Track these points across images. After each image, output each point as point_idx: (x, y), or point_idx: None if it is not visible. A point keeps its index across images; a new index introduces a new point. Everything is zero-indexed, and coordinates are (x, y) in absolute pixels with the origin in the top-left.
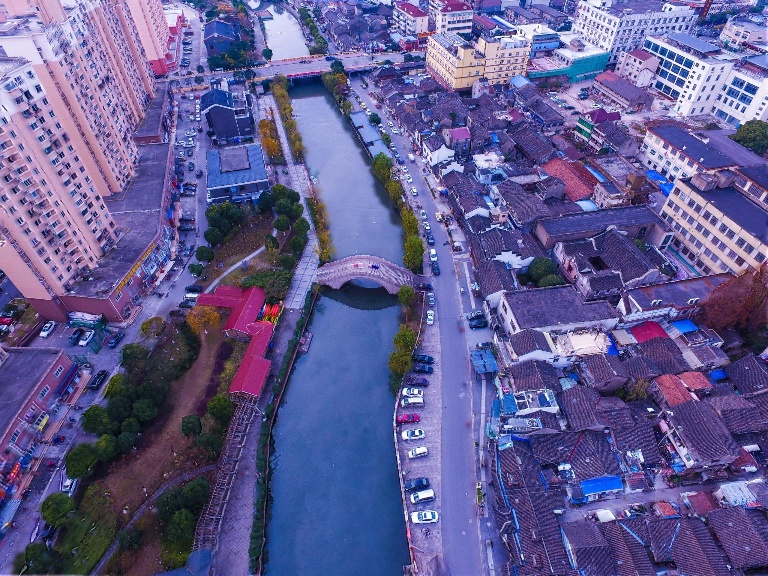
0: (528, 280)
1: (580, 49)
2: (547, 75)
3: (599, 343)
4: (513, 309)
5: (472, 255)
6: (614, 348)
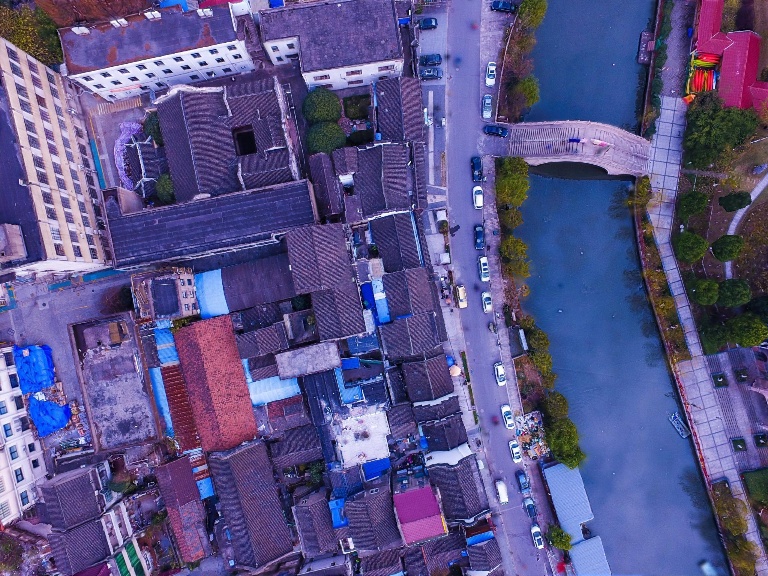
0: (348, 139)
1: None
2: None
3: None
4: (395, 29)
5: None
6: (272, 4)
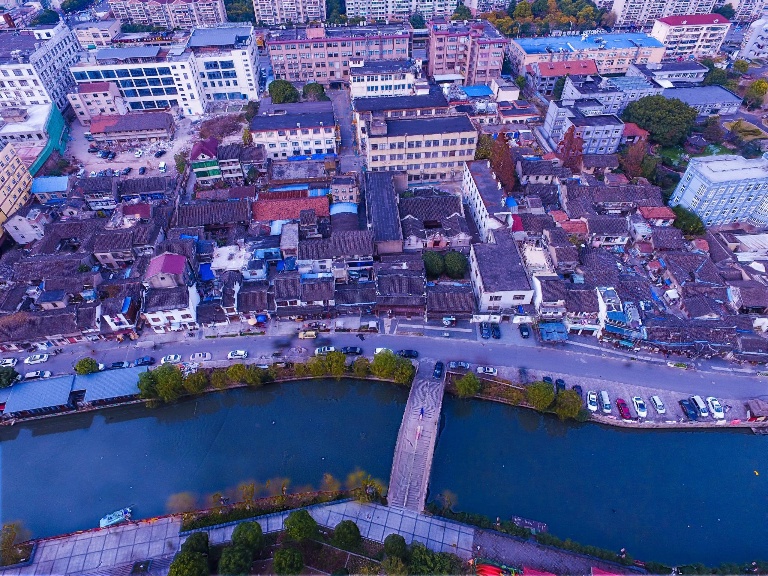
0: None
1: (25, 116)
2: (42, 162)
3: (538, 248)
4: (506, 290)
5: (395, 314)
6: None
